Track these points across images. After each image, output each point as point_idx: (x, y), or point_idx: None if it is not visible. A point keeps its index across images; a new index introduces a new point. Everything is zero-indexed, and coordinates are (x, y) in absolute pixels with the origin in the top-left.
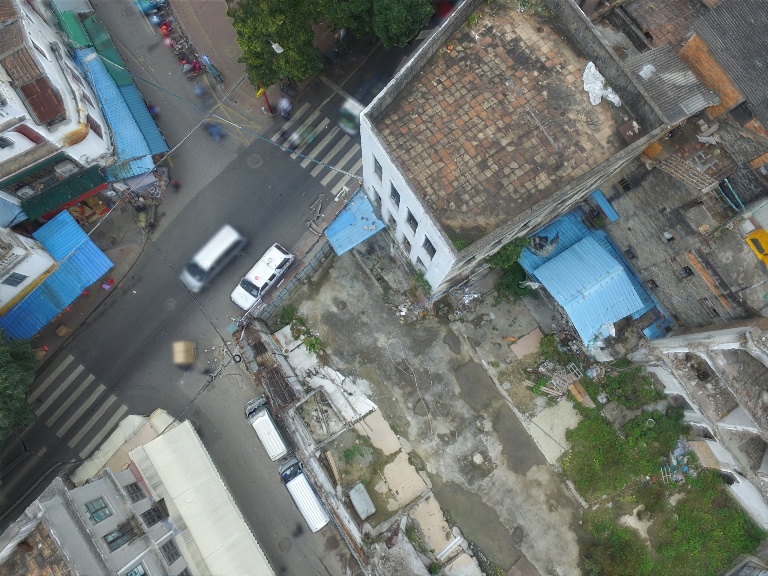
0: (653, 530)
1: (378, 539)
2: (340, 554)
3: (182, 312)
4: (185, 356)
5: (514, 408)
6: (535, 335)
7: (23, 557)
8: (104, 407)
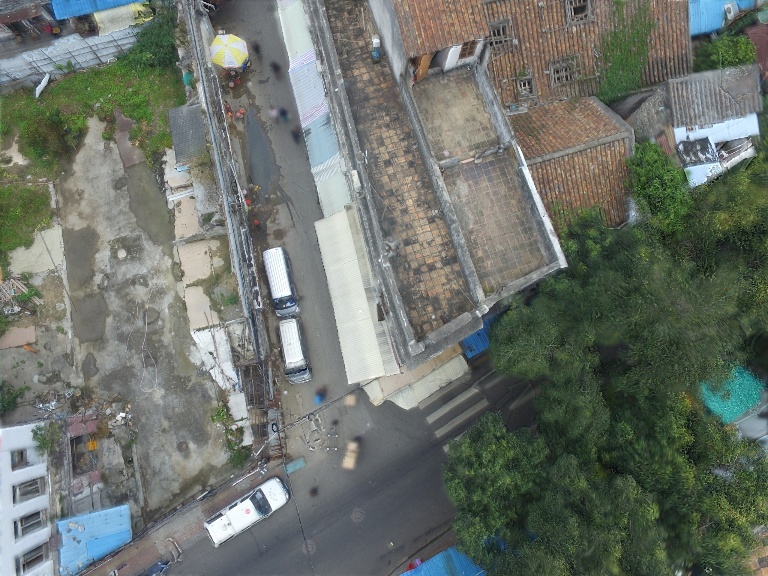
0: (6, 146)
1: (222, 222)
2: (275, 224)
3: (348, 501)
4: (358, 451)
5: (65, 284)
6: (4, 344)
7: (450, 313)
8: (448, 428)
